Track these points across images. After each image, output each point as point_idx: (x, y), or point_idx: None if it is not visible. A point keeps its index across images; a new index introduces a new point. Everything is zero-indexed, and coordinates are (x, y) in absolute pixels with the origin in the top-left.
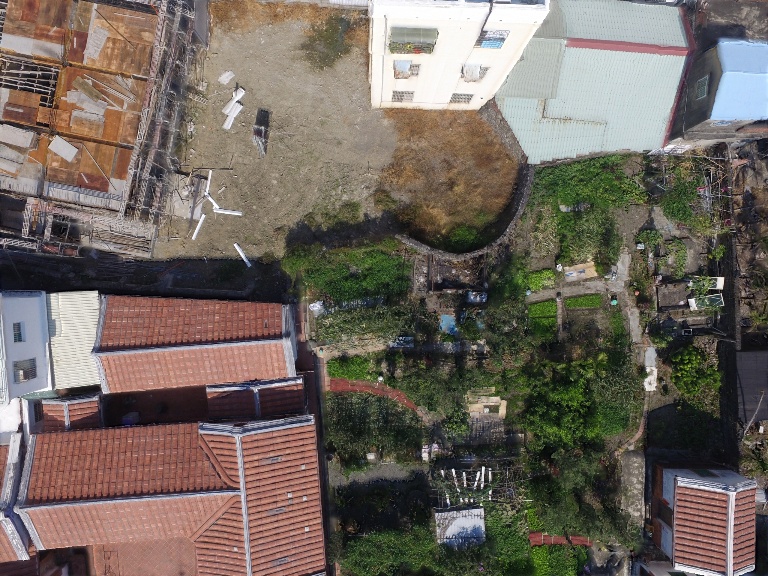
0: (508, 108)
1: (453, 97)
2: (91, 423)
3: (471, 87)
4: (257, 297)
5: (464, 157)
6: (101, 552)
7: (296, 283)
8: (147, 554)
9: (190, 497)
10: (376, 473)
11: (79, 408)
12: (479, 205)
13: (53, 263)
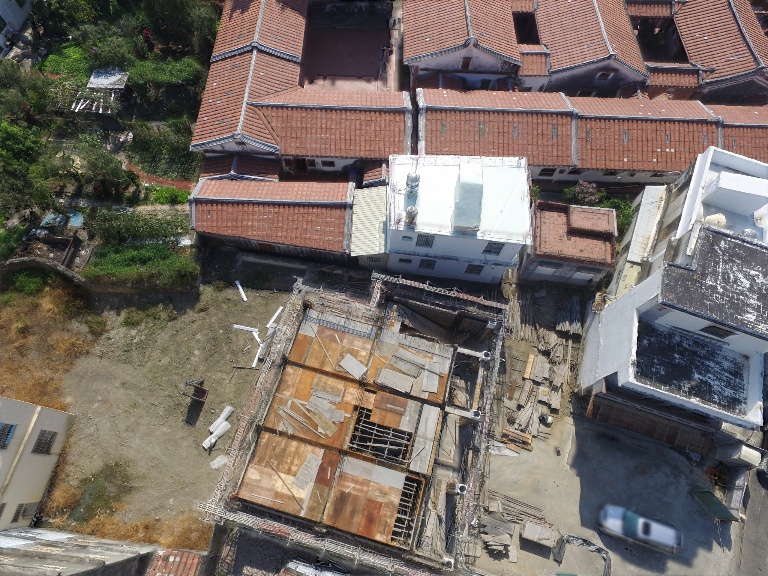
0: None
1: None
2: (369, 167)
3: None
4: None
5: (3, 357)
6: None
7: None
8: None
9: None
10: None
11: (376, 176)
12: (6, 310)
13: None
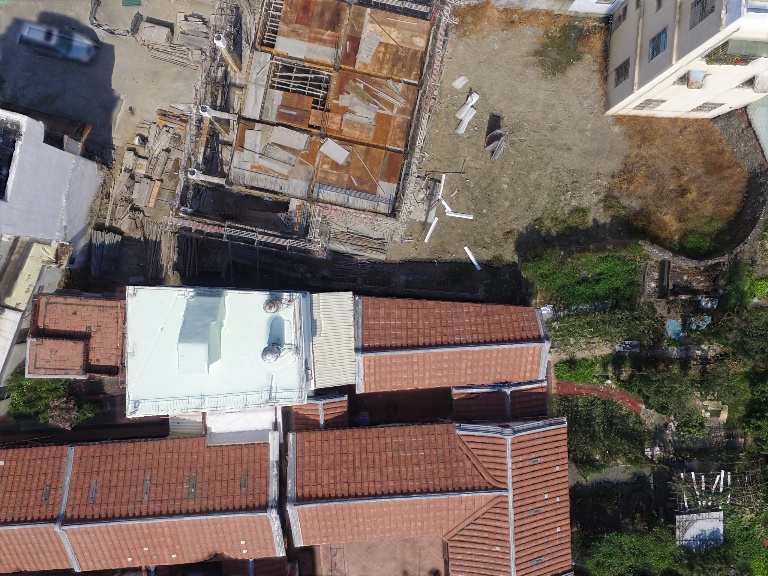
0: (758, 118)
1: (700, 106)
2: (341, 422)
3: (732, 97)
4: (486, 300)
5: (694, 165)
6: (327, 549)
7: (528, 287)
8: (372, 552)
9: (456, 497)
10: (599, 475)
11: (331, 407)
12: (710, 212)
13: (288, 263)
